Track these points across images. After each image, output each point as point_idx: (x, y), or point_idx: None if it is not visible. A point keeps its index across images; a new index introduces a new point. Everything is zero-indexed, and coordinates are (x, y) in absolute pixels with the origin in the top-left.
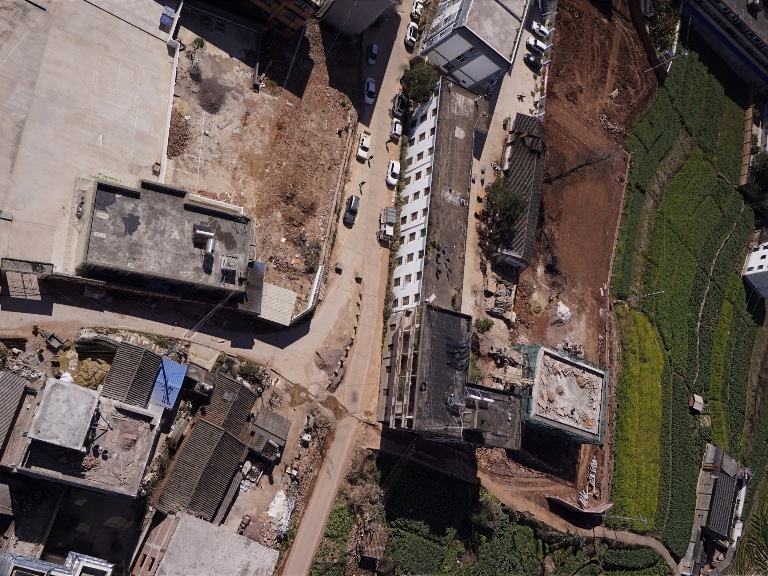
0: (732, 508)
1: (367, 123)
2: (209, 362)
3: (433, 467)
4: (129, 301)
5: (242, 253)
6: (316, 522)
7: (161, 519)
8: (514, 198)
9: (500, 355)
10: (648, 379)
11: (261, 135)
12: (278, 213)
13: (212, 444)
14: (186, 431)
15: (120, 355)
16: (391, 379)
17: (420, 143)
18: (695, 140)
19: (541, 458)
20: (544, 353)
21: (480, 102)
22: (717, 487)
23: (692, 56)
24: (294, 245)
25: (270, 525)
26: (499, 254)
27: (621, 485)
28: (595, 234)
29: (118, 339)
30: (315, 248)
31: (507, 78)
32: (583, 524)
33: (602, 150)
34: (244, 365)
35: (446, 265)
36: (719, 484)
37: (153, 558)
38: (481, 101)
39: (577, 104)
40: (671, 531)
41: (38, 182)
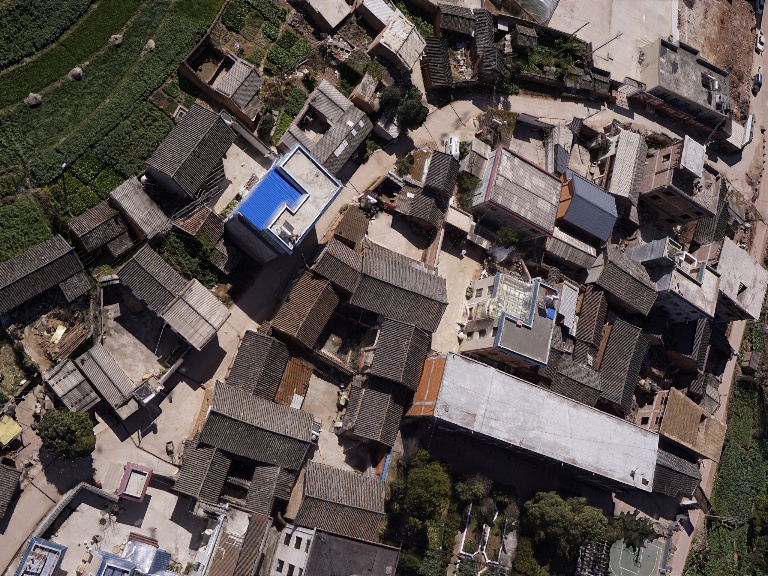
0: None
1: (759, 27)
2: None
3: None
4: (664, 119)
5: None
6: None
7: (695, 250)
8: None
9: None
10: None
11: (714, 26)
12: None
13: (719, 209)
14: None
15: None
16: None
17: None
18: None
19: None
20: None
21: None
22: None
23: None
24: (734, 100)
25: None
26: None
27: None
28: None
29: None
30: (746, 103)
31: None
32: None
33: None
34: None
35: None
36: None
37: None
38: None
39: None
40: None
41: (621, 39)
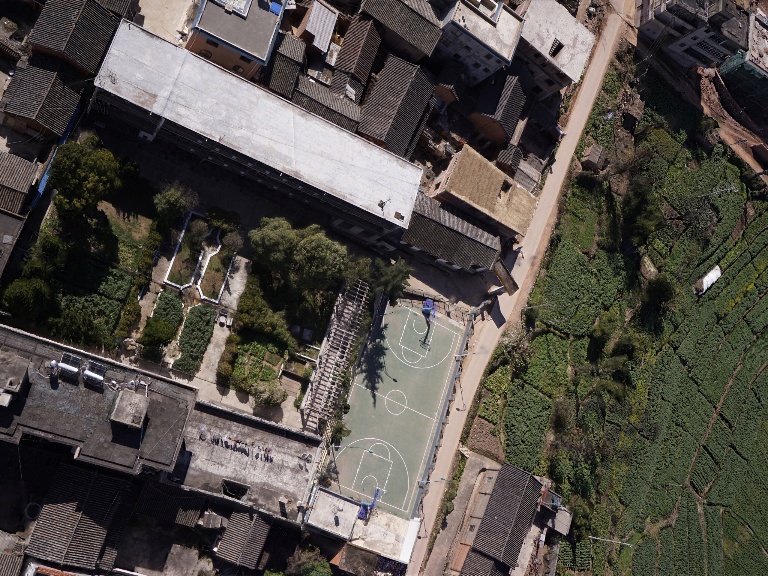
0: None
1: None
2: None
3: (671, 80)
4: None
5: None
6: (596, 76)
7: None
8: None
9: None
10: None
11: None
12: None
13: None
14: None
15: None
16: None
17: None
18: None
19: (747, 114)
20: (755, 18)
21: None
22: None
23: None
24: None
25: None
26: None
27: None
28: None
29: None
30: None
31: None
32: None
33: None
34: None
35: None
36: None
37: None
38: None
39: None
40: None
41: None
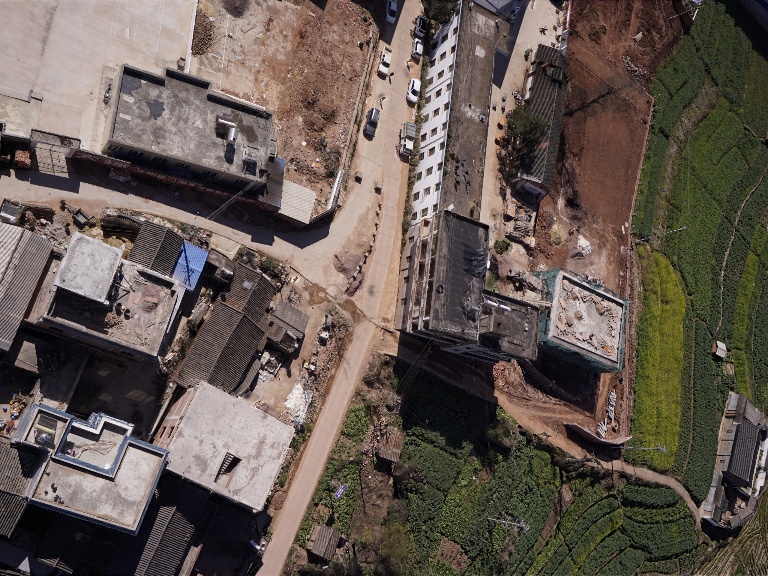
0: (755, 454)
1: (388, 41)
2: (230, 253)
3: (450, 380)
4: (153, 187)
5: (263, 147)
6: (333, 419)
7: (181, 394)
8: (534, 121)
9: (519, 278)
10: (670, 321)
11: (284, 41)
12: (299, 117)
13: (231, 326)
14: (206, 316)
15: (143, 233)
16: (409, 288)
17: (441, 62)
18: (721, 91)
19: (559, 385)
20: (563, 277)
21: (501, 24)
22: (739, 432)
23: (719, 7)
24: (315, 149)
25: (287, 415)
26: (519, 179)
27: (641, 421)
28: (617, 173)
29: (142, 219)
30: (335, 153)
31: (529, 11)
32: (601, 456)
33: (625, 91)
34: (264, 259)
35: (465, 177)
36: (741, 430)
37: (172, 427)
38: (502, 23)
39: (600, 44)
40: (692, 473)
41: (67, 67)
